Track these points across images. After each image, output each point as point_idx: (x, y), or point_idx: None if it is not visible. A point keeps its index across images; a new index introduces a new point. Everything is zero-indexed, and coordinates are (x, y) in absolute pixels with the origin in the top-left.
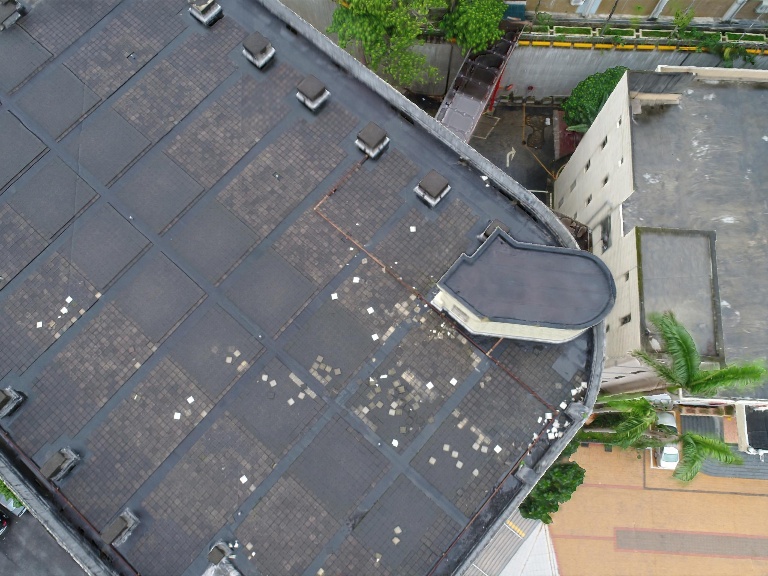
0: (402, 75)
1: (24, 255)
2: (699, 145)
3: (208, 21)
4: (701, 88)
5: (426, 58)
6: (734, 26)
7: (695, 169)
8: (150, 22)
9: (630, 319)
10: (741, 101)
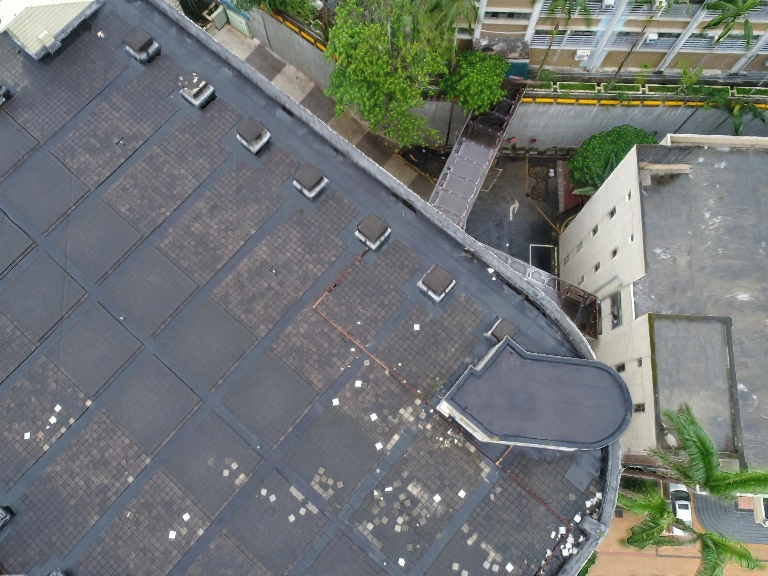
0: (402, 138)
1: (10, 360)
2: (711, 217)
3: (200, 103)
4: (712, 156)
5: (426, 114)
6: (742, 78)
7: (707, 243)
8: (140, 105)
9: (644, 410)
10: (754, 169)
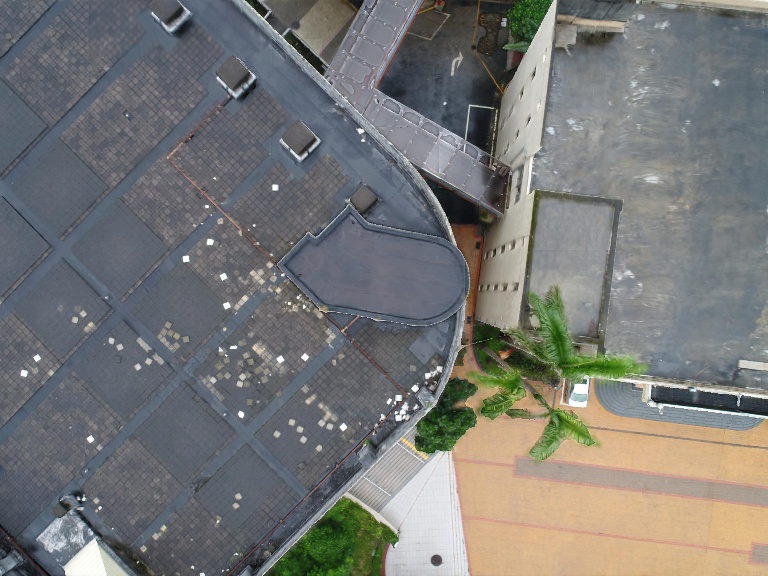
0: None
1: None
2: (637, 86)
3: None
4: (654, 13)
5: None
6: None
7: (627, 116)
8: None
9: None
10: (698, 33)
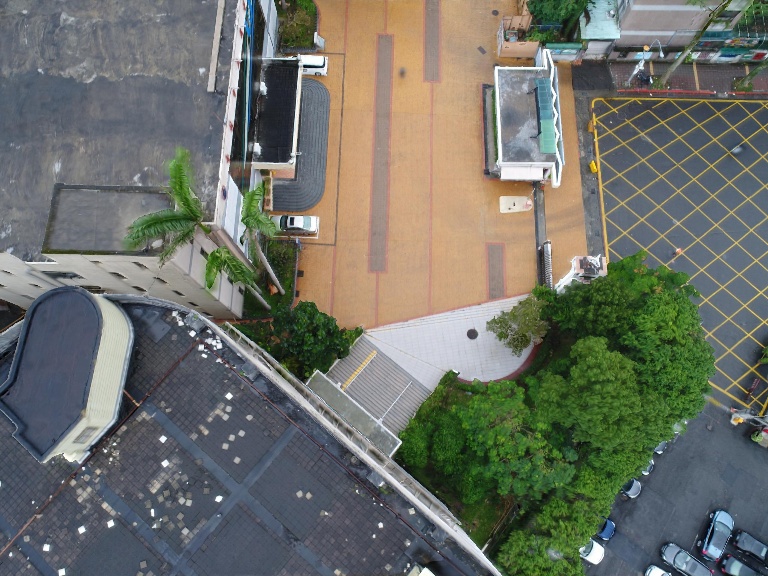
0: None
1: None
2: None
3: None
4: None
5: None
6: None
7: (2, 191)
8: None
9: None
10: None
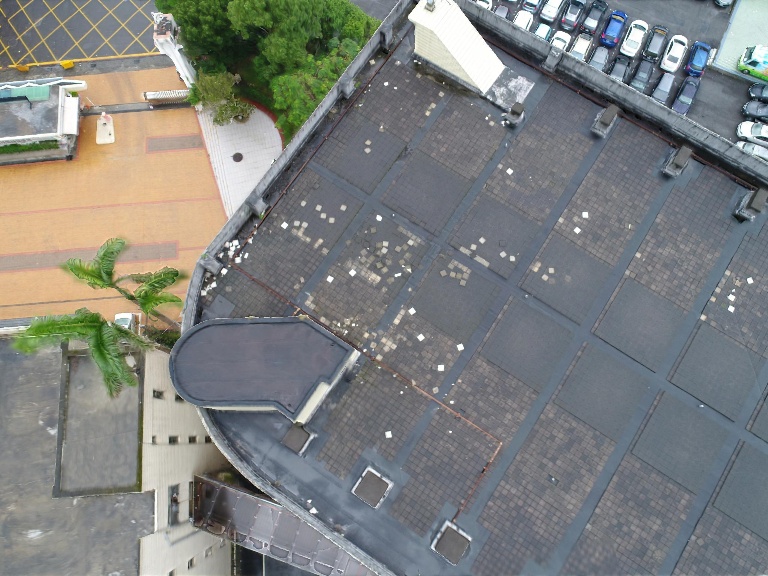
0: None
1: None
2: None
3: None
4: None
5: None
6: None
7: None
8: None
9: None
10: None
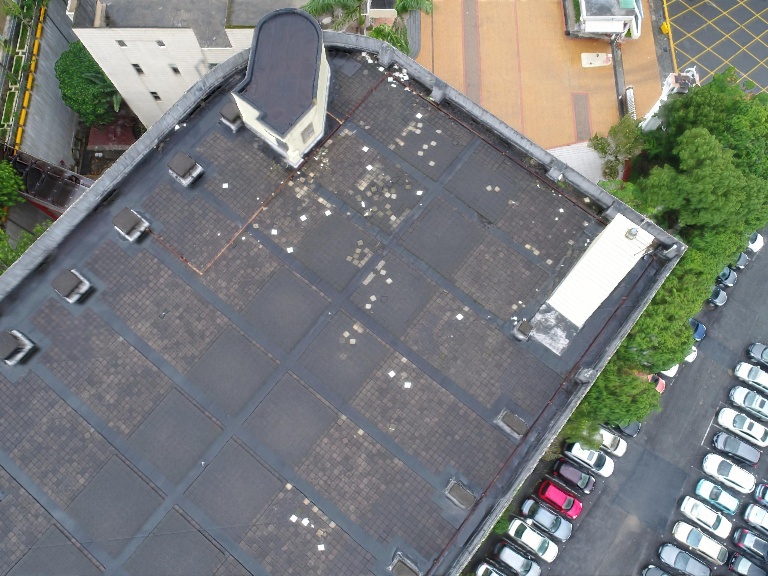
0: None
1: None
2: None
3: None
4: None
5: None
6: None
7: None
8: None
9: None
10: None
